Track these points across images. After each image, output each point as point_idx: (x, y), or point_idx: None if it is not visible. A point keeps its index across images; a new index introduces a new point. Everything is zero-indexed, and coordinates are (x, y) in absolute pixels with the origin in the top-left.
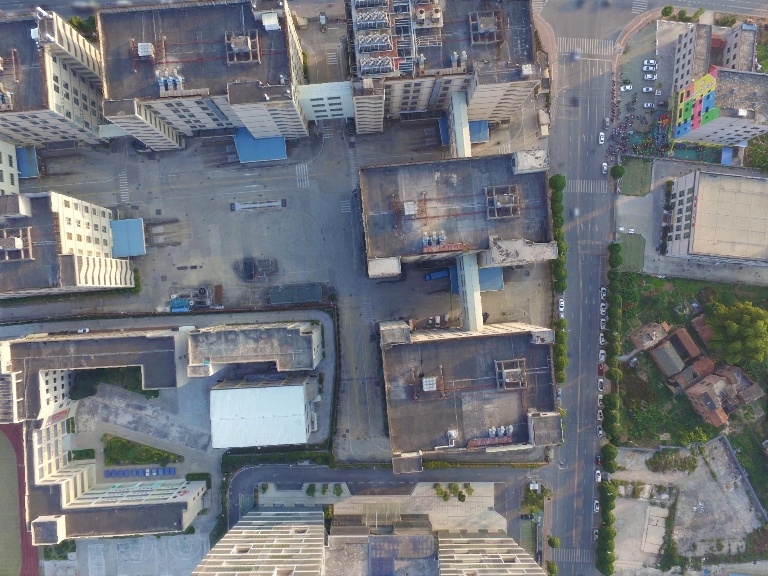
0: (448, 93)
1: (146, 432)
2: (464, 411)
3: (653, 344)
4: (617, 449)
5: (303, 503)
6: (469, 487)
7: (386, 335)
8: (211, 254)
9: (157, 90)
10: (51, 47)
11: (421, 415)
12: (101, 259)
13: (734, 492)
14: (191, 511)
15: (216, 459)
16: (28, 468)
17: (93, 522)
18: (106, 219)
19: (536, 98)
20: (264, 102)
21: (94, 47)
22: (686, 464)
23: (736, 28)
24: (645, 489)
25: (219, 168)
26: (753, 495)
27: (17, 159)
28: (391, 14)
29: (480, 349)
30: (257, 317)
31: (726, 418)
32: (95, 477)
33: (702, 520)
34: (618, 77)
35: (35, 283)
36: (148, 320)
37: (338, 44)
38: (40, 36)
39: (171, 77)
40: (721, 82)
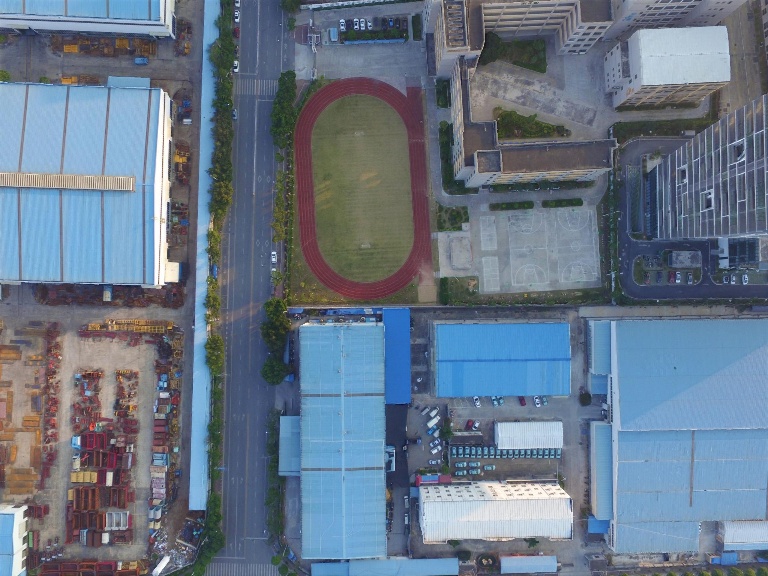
0: None
1: (534, 107)
2: None
3: None
4: None
5: None
6: None
7: None
8: None
9: None
10: None
11: None
12: None
13: None
14: None
15: (601, 133)
16: (463, 106)
17: (525, 160)
18: None
19: None
20: None
21: None
22: None
23: None
24: None
25: None
26: None
27: None
28: None
29: None
30: None
31: None
32: None
33: None
34: None
35: None
36: None
37: None
38: None
39: None
40: None
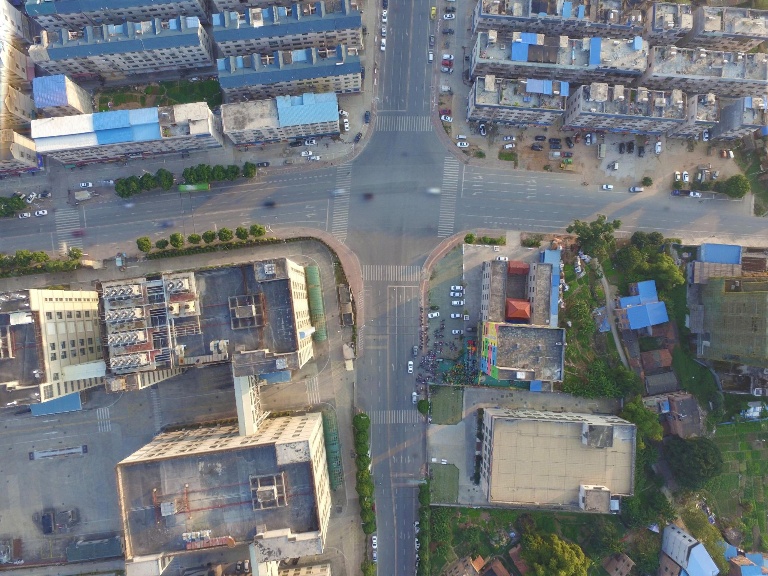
0: None
1: None
2: None
3: None
4: None
5: None
6: None
7: None
8: (9, 506)
9: None
10: None
11: None
12: None
13: None
14: None
15: None
16: None
17: None
18: None
19: (342, 329)
20: None
21: None
22: None
23: (542, 249)
24: None
25: (16, 416)
26: None
27: None
28: (145, 305)
29: None
30: (59, 570)
31: None
32: None
33: None
34: (426, 303)
35: None
36: None
37: None
38: None
39: None
40: (504, 337)
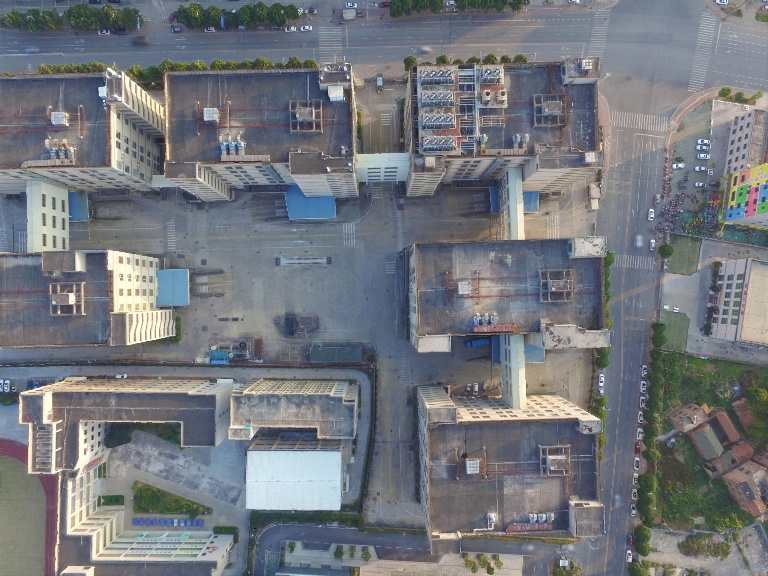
0: (504, 168)
1: (177, 482)
2: (505, 494)
3: (693, 427)
4: (650, 530)
5: (330, 564)
6: (498, 560)
7: (432, 414)
8: (253, 307)
9: (218, 153)
10: (117, 105)
11: (462, 496)
12: (149, 313)
13: None
14: (219, 568)
15: (245, 513)
16: (61, 517)
17: (121, 575)
18: (153, 268)
19: None
20: (325, 173)
21: (151, 95)
22: (719, 550)
23: None
24: (676, 572)
25: (267, 222)
26: None
27: (69, 203)
28: (456, 92)
29: (525, 432)
30: (295, 373)
31: (764, 508)
32: (123, 524)
33: None
34: (671, 154)
35: (84, 338)
36: (186, 369)
37: (393, 105)
38: (107, 95)
39: (233, 142)
40: None
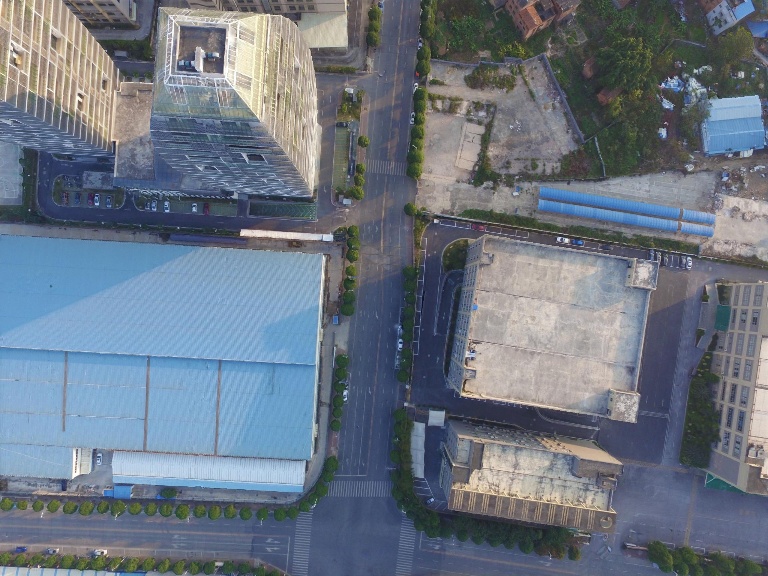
0: None
1: None
2: None
3: None
4: (436, 63)
5: None
6: None
7: None
8: None
9: None
10: None
11: None
12: None
13: (552, 113)
14: None
15: None
16: None
17: None
18: None
19: None
20: None
21: None
22: (504, 81)
23: None
24: (463, 105)
25: None
26: (571, 116)
27: None
28: None
29: None
30: None
31: (540, 21)
32: None
33: (518, 139)
34: None
35: None
36: None
37: None
38: None
39: None
40: None
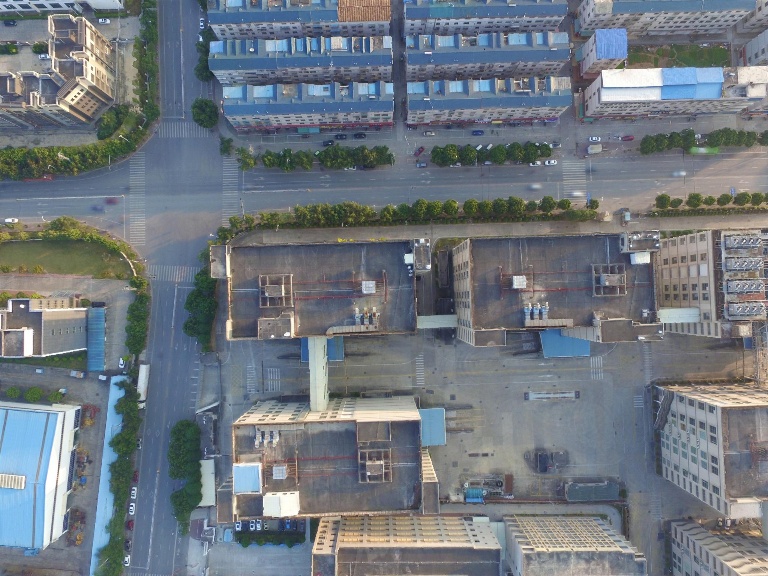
0: None
1: None
2: None
3: None
4: None
5: None
6: None
7: None
8: (503, 442)
9: (520, 317)
10: None
11: None
12: None
13: None
14: None
15: None
16: None
17: None
18: None
19: None
20: None
21: (397, 230)
22: None
23: None
24: None
25: (515, 356)
26: None
27: (327, 344)
28: (760, 257)
29: None
30: (546, 508)
31: None
32: None
33: None
34: None
35: (390, 504)
36: None
37: None
38: (415, 262)
39: None
40: None
